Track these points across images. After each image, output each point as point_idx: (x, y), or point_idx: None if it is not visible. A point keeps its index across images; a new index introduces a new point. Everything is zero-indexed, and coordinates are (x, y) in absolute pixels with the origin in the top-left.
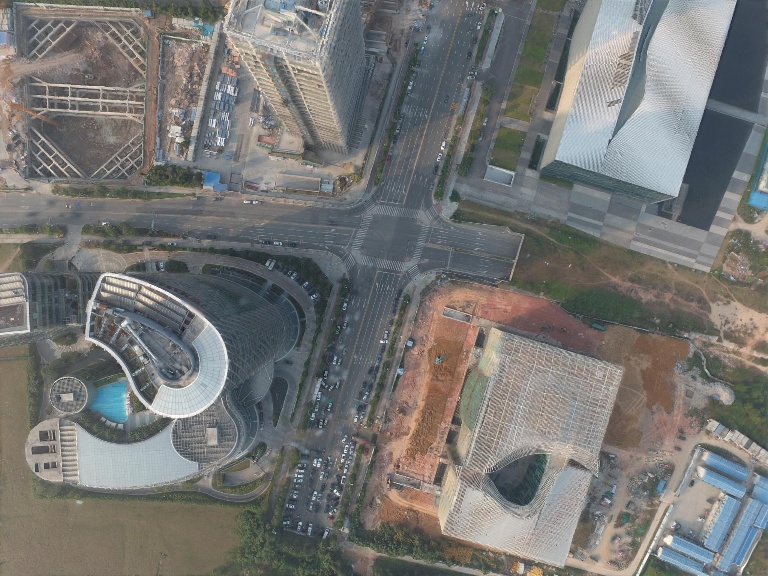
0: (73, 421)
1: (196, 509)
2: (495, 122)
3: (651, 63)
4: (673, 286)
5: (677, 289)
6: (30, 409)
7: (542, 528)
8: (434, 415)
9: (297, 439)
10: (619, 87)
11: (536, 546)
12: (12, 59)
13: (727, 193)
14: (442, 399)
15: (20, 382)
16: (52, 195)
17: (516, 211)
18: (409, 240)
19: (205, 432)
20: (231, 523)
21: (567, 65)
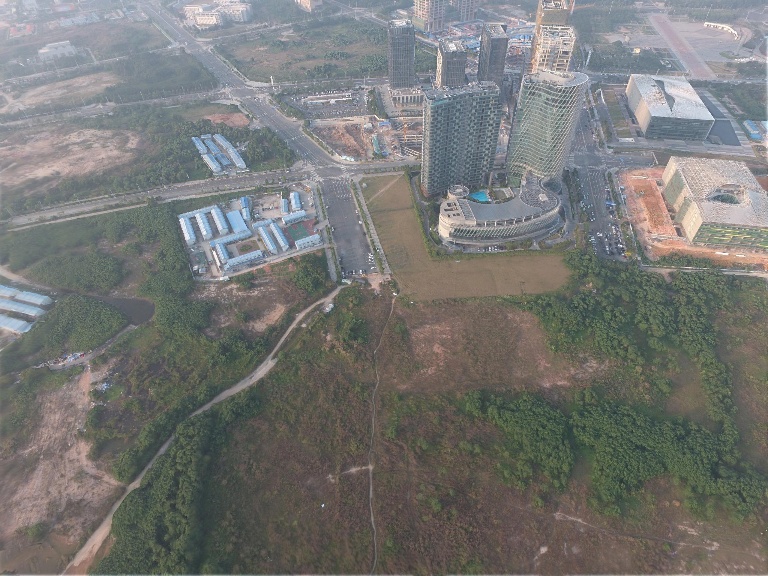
0: (464, 199)
1: (534, 259)
2: (612, 129)
3: (670, 93)
4: (743, 161)
5: (746, 162)
6: (423, 219)
7: (760, 213)
8: (656, 211)
9: (581, 227)
10: (662, 100)
11: (764, 221)
12: (390, 130)
13: (738, 136)
14: (655, 205)
15: (410, 216)
16: (414, 160)
17: (643, 148)
18: (596, 160)
19: (538, 198)
20: (561, 264)
21: (633, 112)
